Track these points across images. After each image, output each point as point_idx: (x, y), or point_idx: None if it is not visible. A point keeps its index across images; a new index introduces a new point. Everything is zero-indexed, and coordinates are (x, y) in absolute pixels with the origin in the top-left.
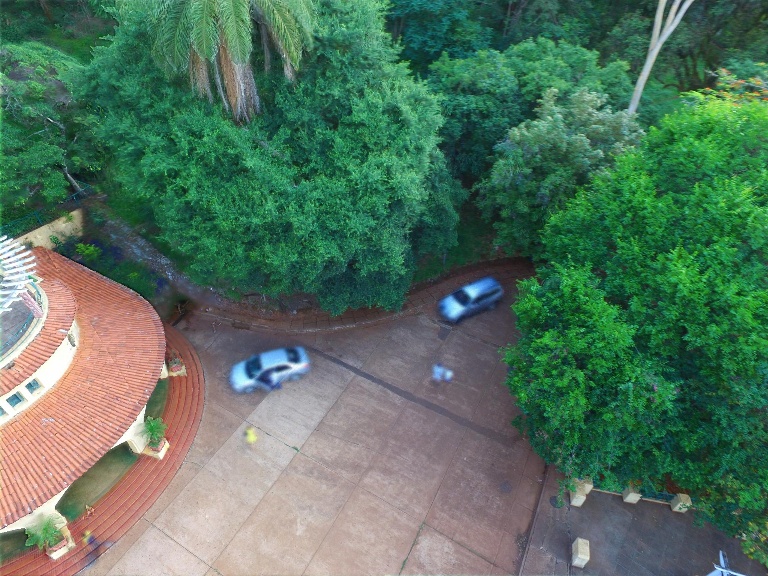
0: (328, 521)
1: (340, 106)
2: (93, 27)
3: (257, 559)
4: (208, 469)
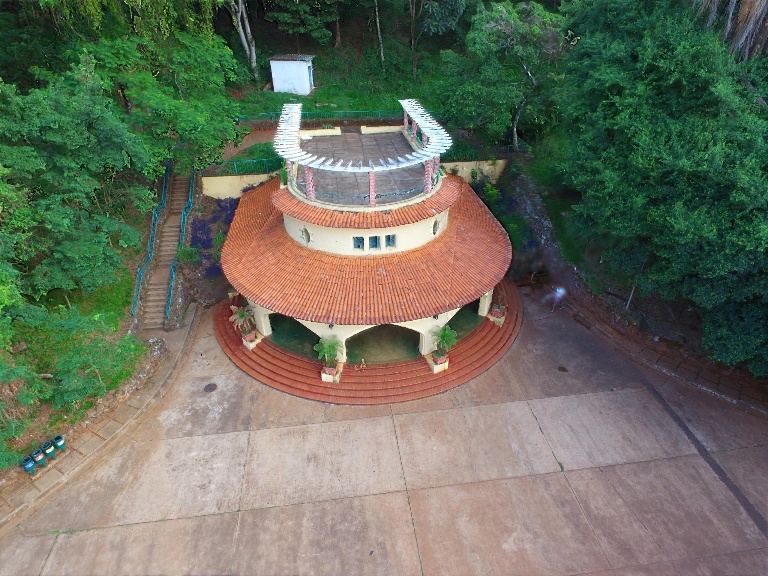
0: (547, 569)
1: None
2: None
3: (448, 526)
4: (464, 412)
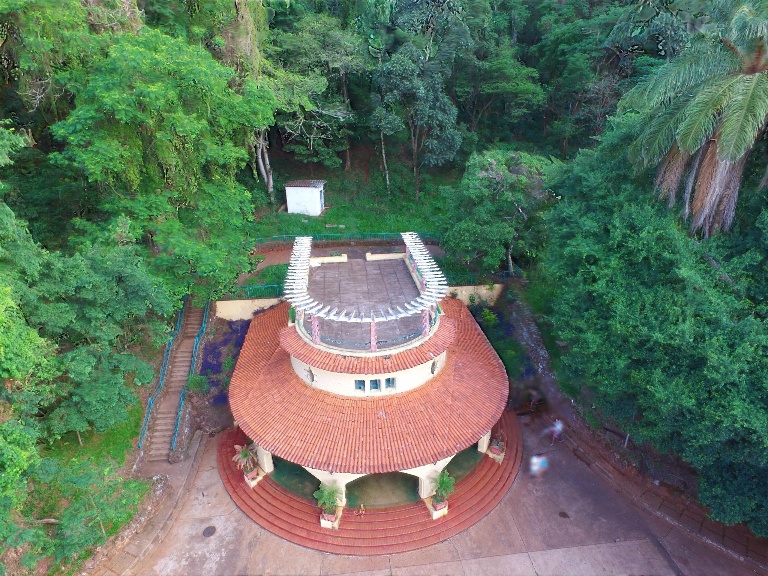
0: None
1: None
2: None
3: None
4: (463, 567)
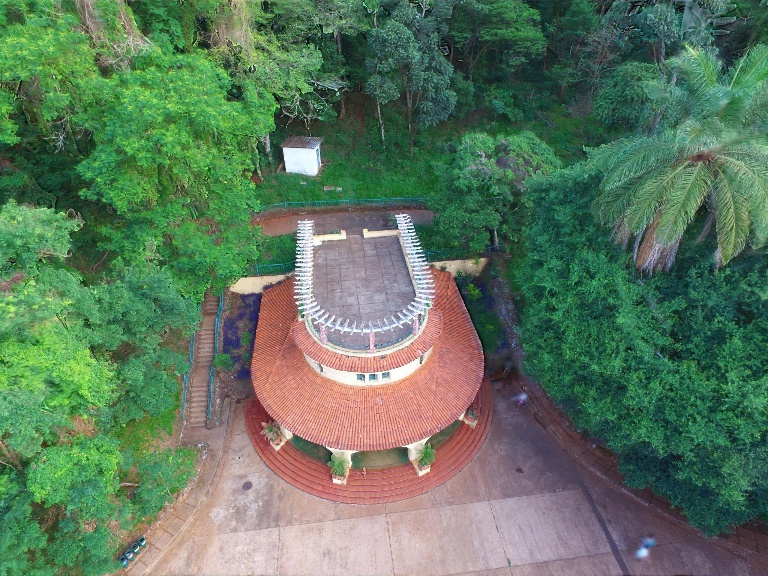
0: None
1: (766, 306)
2: (589, 114)
3: None
4: (440, 512)
